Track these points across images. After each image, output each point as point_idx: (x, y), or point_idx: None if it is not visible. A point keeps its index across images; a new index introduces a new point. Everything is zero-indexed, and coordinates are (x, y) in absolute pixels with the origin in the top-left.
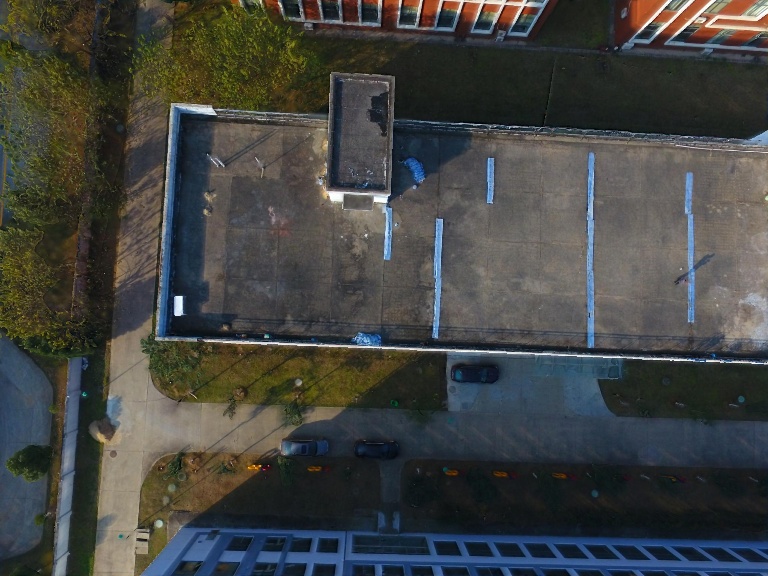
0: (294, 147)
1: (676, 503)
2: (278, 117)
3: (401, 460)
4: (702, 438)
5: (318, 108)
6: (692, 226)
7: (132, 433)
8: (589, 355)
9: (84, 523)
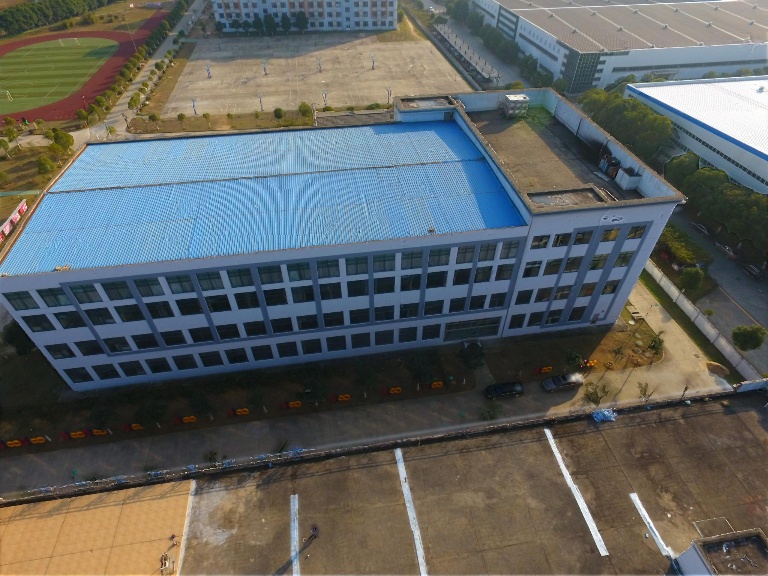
0: None
1: (235, 396)
2: None
3: (480, 388)
4: (203, 453)
5: None
6: None
7: (696, 371)
8: None
9: (679, 316)
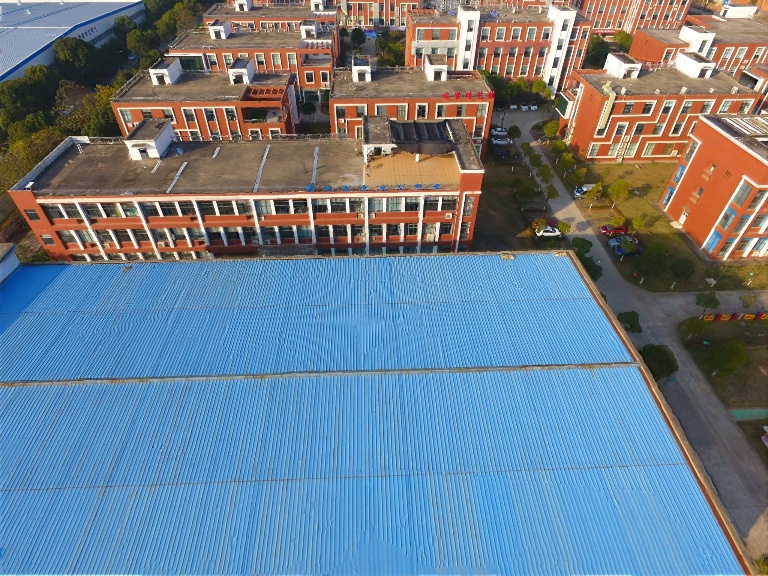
0: (123, 149)
1: None
2: (119, 141)
3: None
4: None
5: None
6: None
7: None
8: (254, 195)
9: None
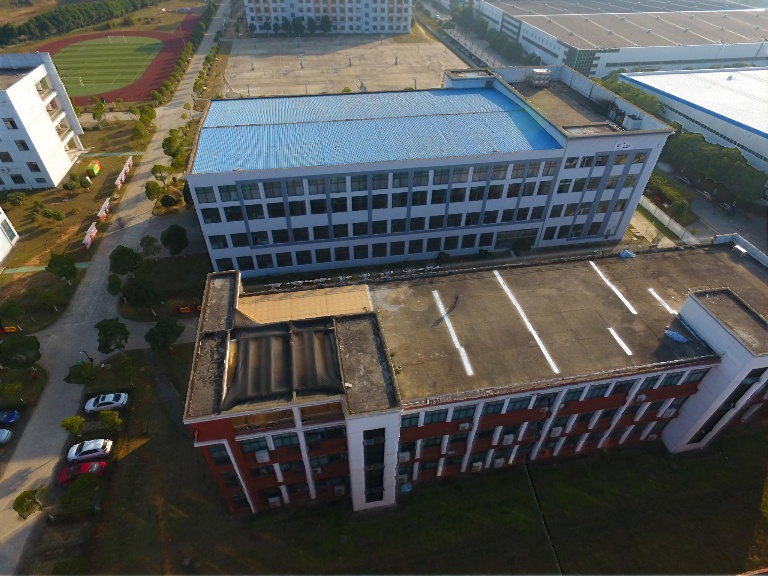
0: None
1: None
2: None
3: None
4: None
5: (766, 487)
6: (455, 341)
7: None
8: None
9: (670, 235)
